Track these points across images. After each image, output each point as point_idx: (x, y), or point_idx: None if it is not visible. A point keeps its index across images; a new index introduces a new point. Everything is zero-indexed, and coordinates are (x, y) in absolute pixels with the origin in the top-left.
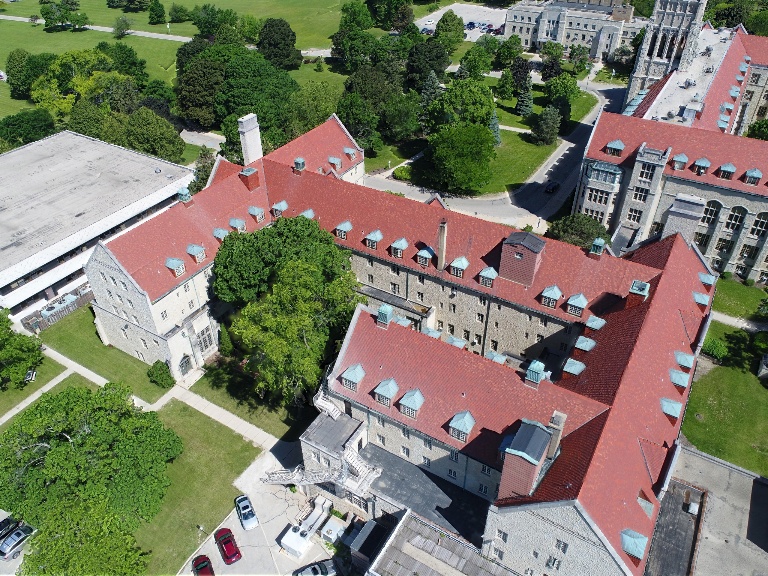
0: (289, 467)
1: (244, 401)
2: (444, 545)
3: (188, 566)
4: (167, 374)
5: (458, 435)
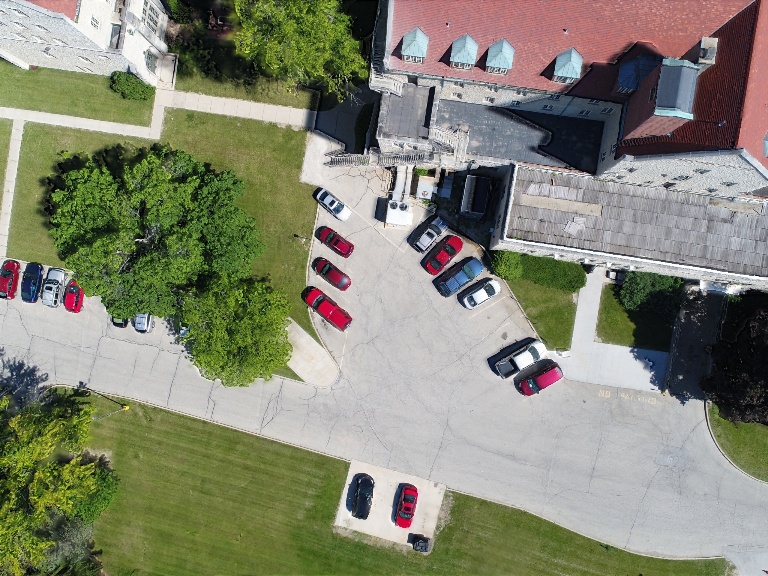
0: (346, 139)
1: (249, 79)
2: (559, 183)
3: (311, 272)
4: (140, 85)
5: (564, 80)
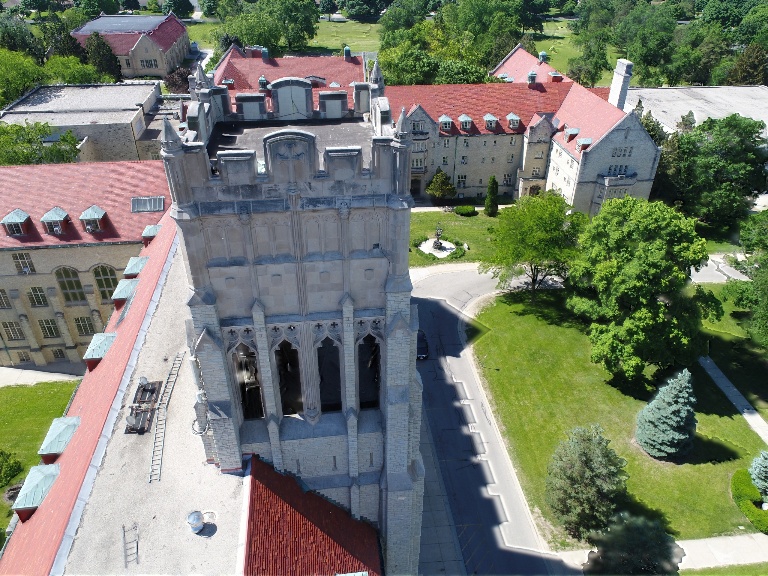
0: None
1: None
2: None
3: None
4: None
5: None
